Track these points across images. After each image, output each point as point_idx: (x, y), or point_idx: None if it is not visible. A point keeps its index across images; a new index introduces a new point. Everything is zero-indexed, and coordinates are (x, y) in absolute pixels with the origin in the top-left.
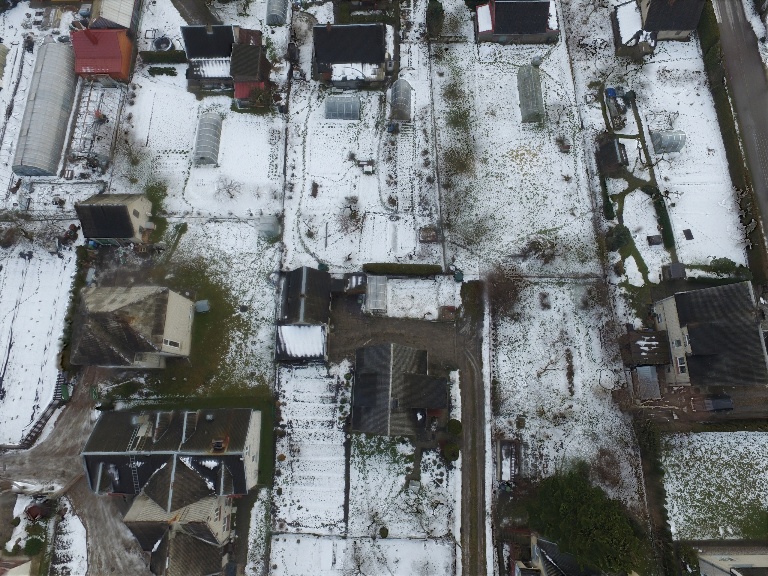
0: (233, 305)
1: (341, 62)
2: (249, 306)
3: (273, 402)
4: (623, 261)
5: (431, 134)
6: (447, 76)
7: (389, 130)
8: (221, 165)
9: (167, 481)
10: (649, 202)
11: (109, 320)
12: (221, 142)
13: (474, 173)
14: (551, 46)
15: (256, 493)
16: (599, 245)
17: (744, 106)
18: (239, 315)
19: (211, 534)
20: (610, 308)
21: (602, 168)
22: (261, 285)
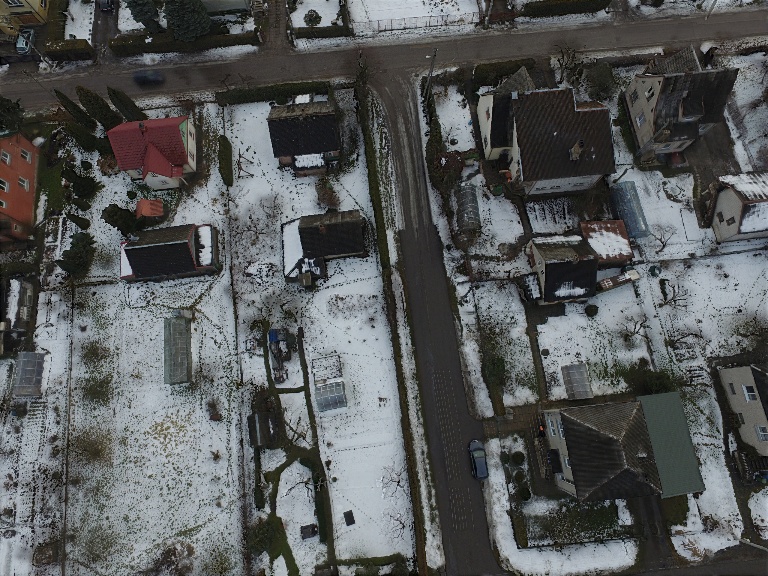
0: None
1: None
2: None
3: None
4: (271, 564)
5: (64, 411)
6: (90, 330)
7: (12, 414)
8: None
9: None
10: (307, 479)
11: None
12: None
13: (110, 460)
14: (213, 278)
15: None
16: None
17: (423, 337)
18: None
19: None
20: None
21: None
22: None
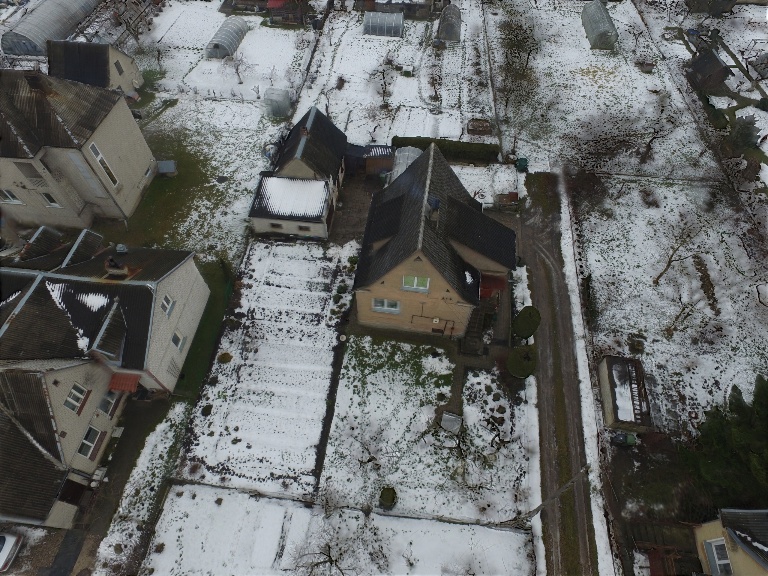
0: (209, 175)
1: None
2: (230, 177)
3: (232, 279)
4: None
5: (483, 52)
6: (502, 15)
7: (435, 44)
8: None
9: (7, 313)
10: None
11: (20, 84)
12: (242, 44)
13: (536, 83)
14: (615, 3)
15: (166, 408)
16: (713, 152)
17: None
18: (214, 185)
19: (48, 419)
20: (749, 215)
21: (698, 85)
22: (252, 158)
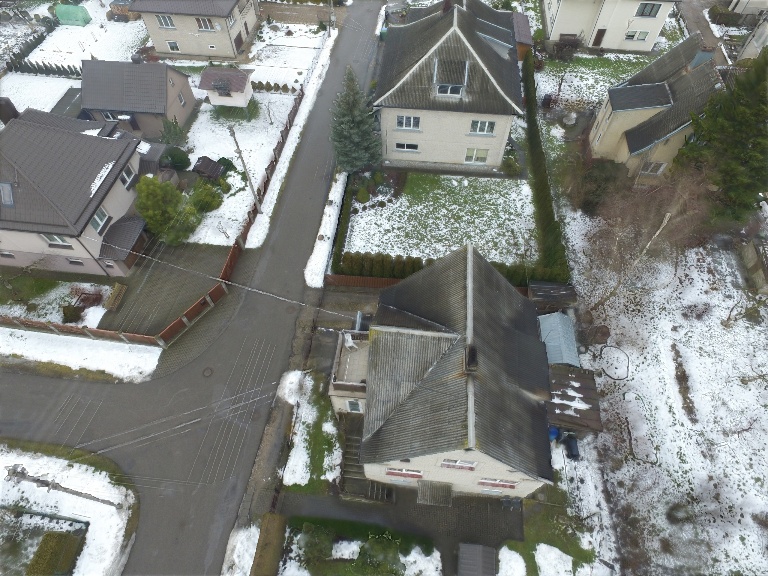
0: None
1: None
2: None
3: None
4: None
5: None
6: None
7: None
8: None
9: None
10: None
11: None
12: None
13: None
14: None
15: None
16: None
17: None
18: None
19: None
20: (612, 501)
21: None
22: None
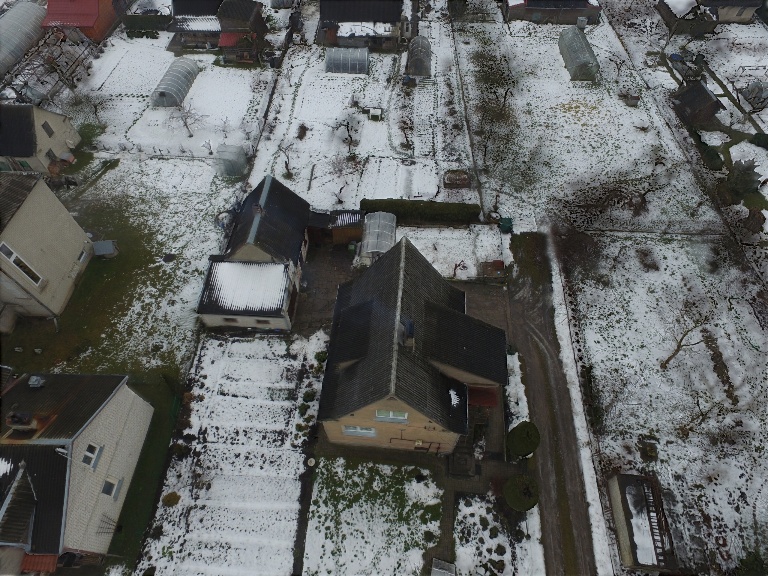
0: (154, 253)
1: (349, 20)
2: (179, 254)
3: (180, 392)
4: None
5: (457, 88)
6: (474, 44)
7: (404, 81)
8: (185, 108)
9: None
10: (766, 153)
11: None
12: (192, 88)
13: (516, 122)
14: (593, 26)
15: (98, 575)
16: (710, 198)
17: None
18: (160, 265)
19: None
20: (756, 274)
21: (688, 119)
22: (204, 229)
